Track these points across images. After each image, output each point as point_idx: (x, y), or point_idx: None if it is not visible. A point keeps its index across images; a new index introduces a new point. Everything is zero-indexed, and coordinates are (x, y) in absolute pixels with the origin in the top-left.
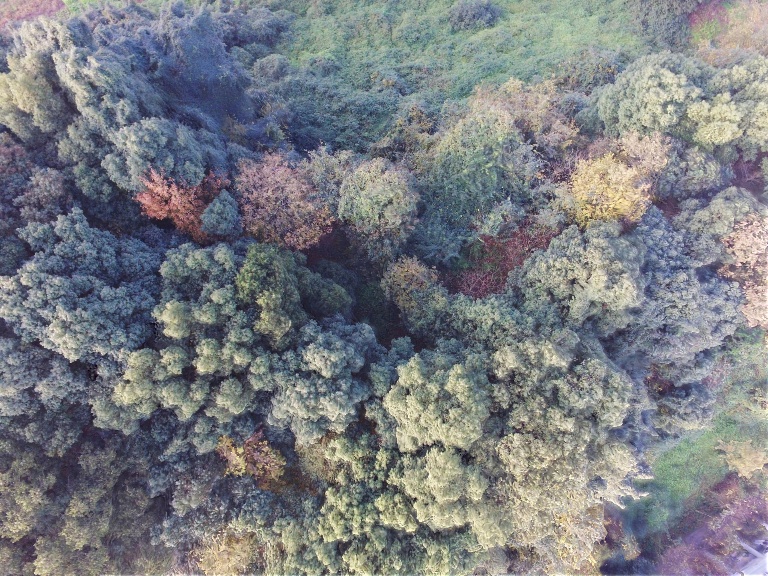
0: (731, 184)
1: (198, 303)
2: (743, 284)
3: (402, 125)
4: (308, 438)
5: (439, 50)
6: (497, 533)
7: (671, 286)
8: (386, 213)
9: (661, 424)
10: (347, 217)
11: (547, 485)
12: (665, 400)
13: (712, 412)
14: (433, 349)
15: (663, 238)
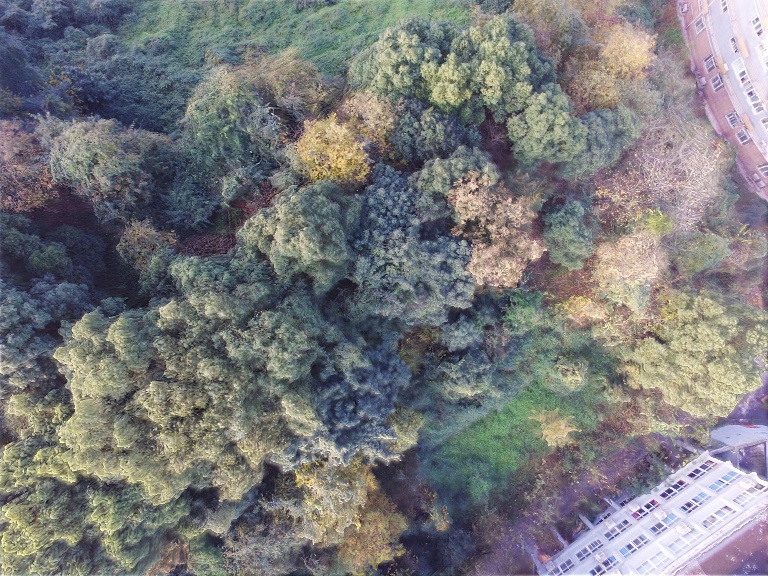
0: (465, 143)
1: None
2: (470, 242)
3: None
4: None
5: (281, 29)
6: (162, 483)
7: (388, 244)
8: (95, 174)
9: (444, 390)
10: (61, 179)
11: (192, 433)
12: (441, 365)
13: (486, 377)
14: None
15: (389, 197)
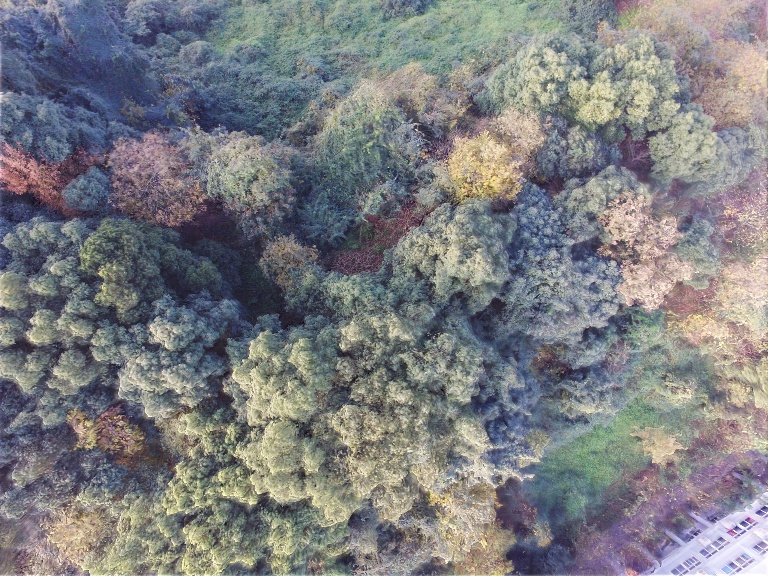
0: (612, 163)
1: (37, 274)
2: (620, 263)
3: (313, 109)
4: (155, 411)
5: (369, 37)
6: (341, 507)
7: (543, 264)
8: (253, 190)
9: (562, 408)
10: (216, 194)
11: (383, 457)
12: (563, 383)
13: (610, 395)
14: (297, 325)
15: (539, 216)
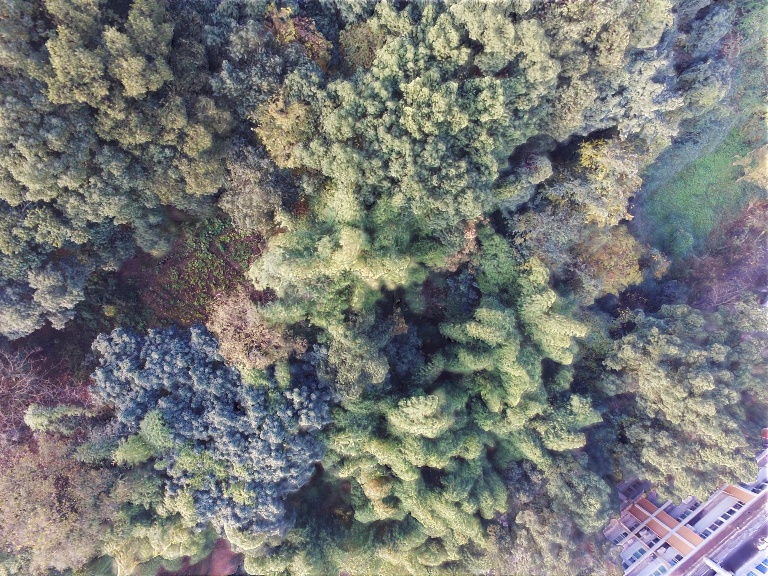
0: None
1: None
2: None
3: None
4: None
5: None
6: (546, 63)
7: None
8: None
9: None
10: None
11: None
12: (684, 73)
13: (730, 79)
14: None
15: None
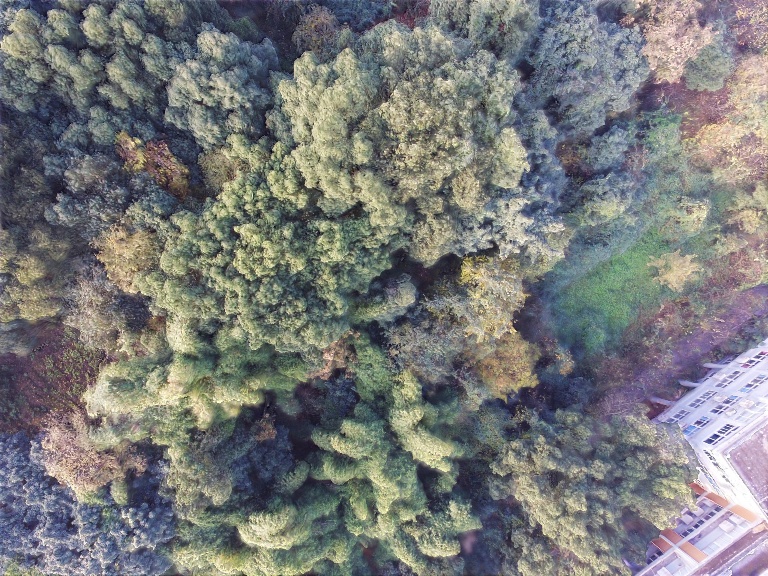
0: None
1: None
2: (643, 28)
3: None
4: (202, 124)
5: None
6: (387, 210)
7: (570, 21)
8: None
9: (584, 214)
10: None
11: (429, 146)
12: (585, 184)
13: (630, 194)
14: None
15: None
